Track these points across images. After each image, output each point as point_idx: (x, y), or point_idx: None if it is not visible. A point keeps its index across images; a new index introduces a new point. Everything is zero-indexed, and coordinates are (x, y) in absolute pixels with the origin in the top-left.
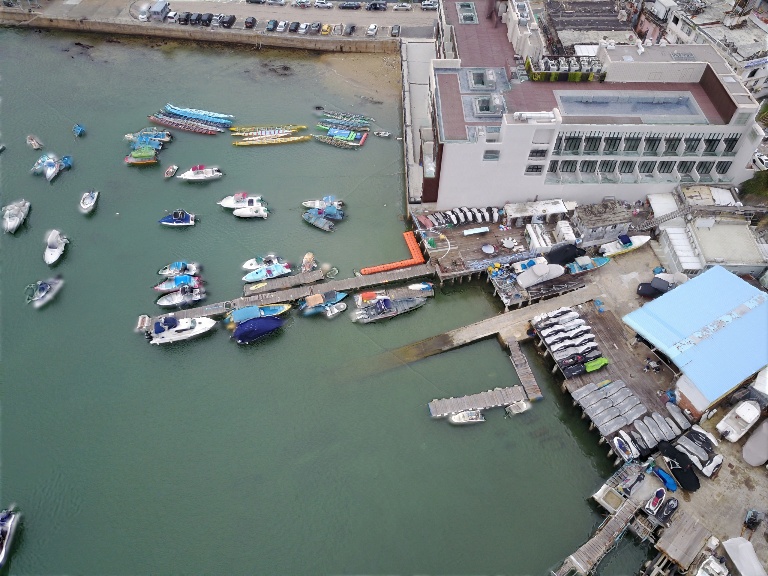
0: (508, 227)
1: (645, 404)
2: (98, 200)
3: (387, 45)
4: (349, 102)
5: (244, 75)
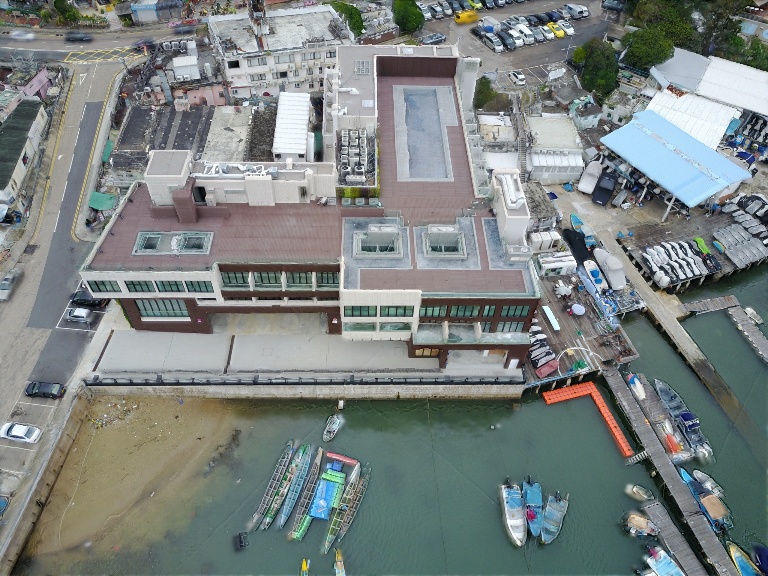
0: None
1: (722, 226)
2: None
3: (77, 411)
4: (223, 487)
5: None
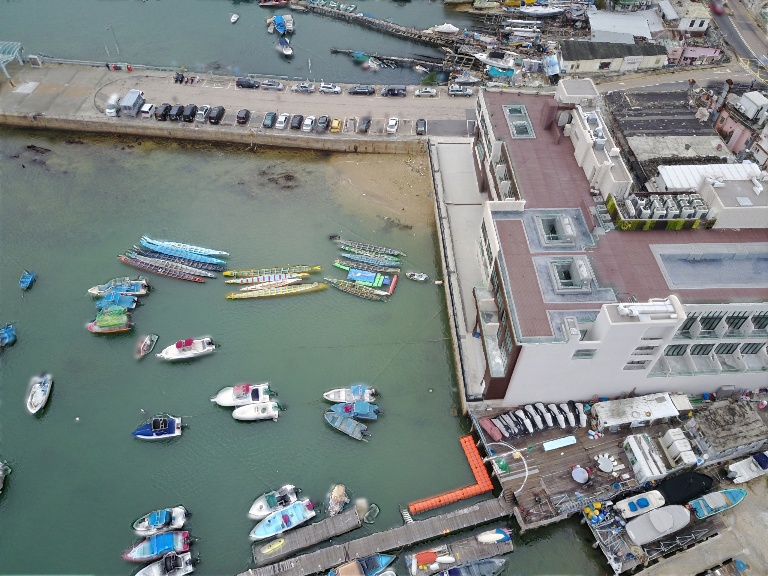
0: (600, 433)
1: None
2: (51, 395)
3: (411, 145)
4: (370, 226)
5: (238, 188)
